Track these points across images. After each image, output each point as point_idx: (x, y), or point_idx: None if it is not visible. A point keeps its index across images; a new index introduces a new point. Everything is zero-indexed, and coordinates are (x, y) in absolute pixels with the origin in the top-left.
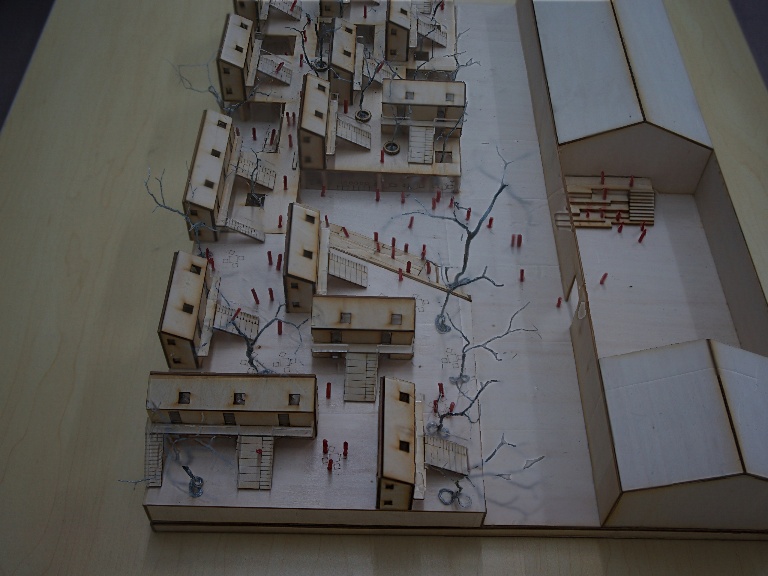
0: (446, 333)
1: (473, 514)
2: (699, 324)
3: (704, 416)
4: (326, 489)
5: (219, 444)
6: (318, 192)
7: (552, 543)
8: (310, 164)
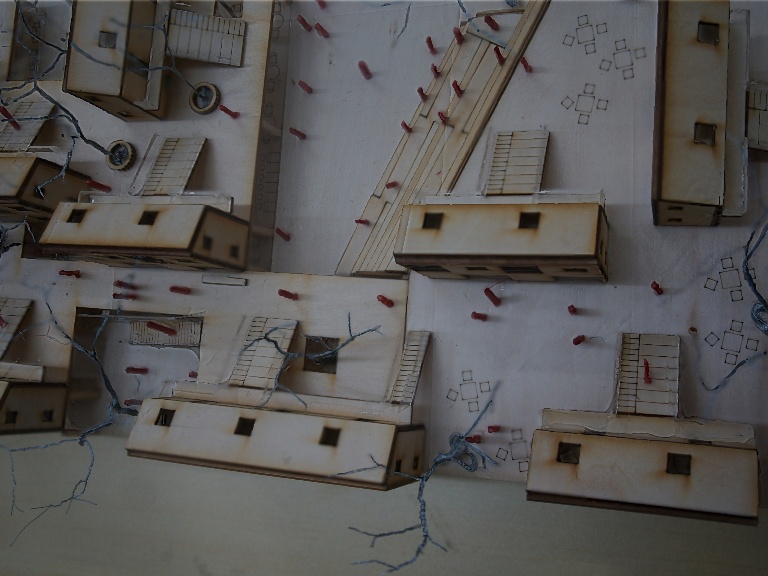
0: None
1: None
2: None
3: None
4: None
5: None
6: (279, 247)
7: None
8: (240, 250)
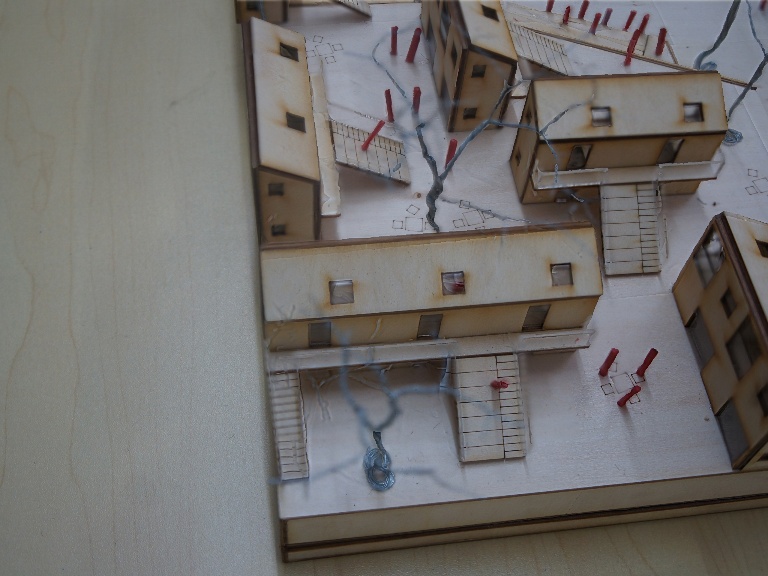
0: (736, 144)
1: None
2: None
3: None
4: (628, 443)
5: (398, 380)
6: None
7: None
8: None
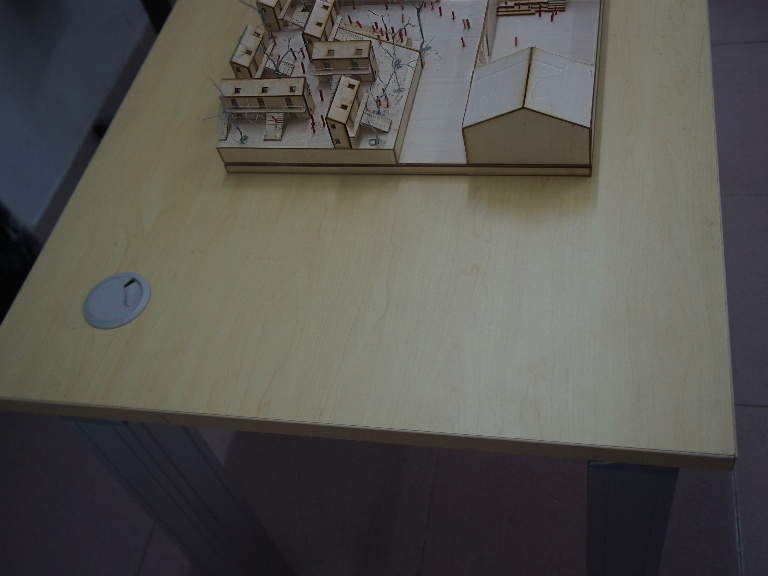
0: (399, 68)
1: (387, 151)
2: (572, 64)
3: (514, 84)
4: (310, 140)
5: (259, 122)
6: (352, 7)
7: None
8: None
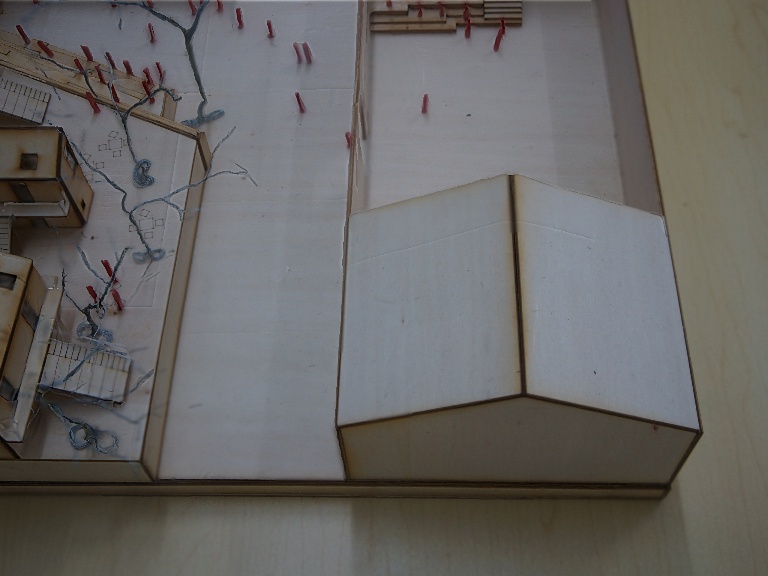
0: (146, 187)
1: (122, 464)
2: (564, 167)
3: (479, 300)
4: None
5: None
6: None
7: (277, 505)
8: None
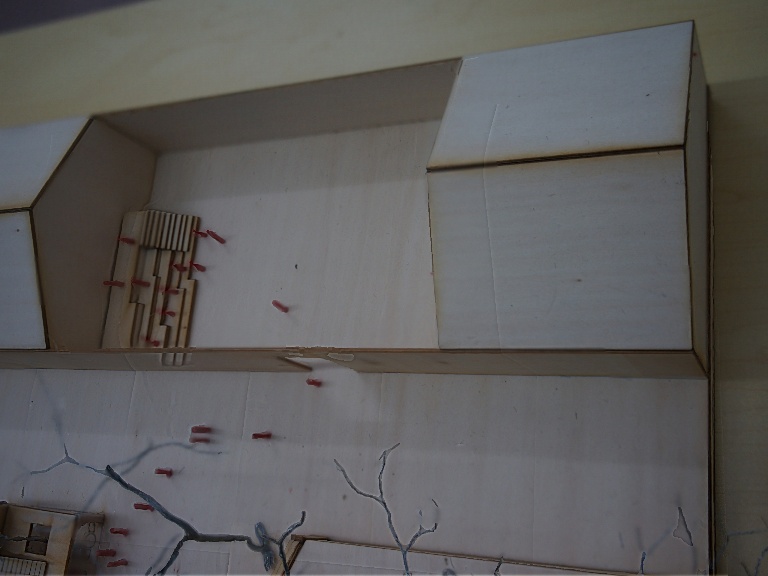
0: None
1: None
2: (367, 177)
3: (570, 197)
4: None
5: None
6: None
7: None
8: None
